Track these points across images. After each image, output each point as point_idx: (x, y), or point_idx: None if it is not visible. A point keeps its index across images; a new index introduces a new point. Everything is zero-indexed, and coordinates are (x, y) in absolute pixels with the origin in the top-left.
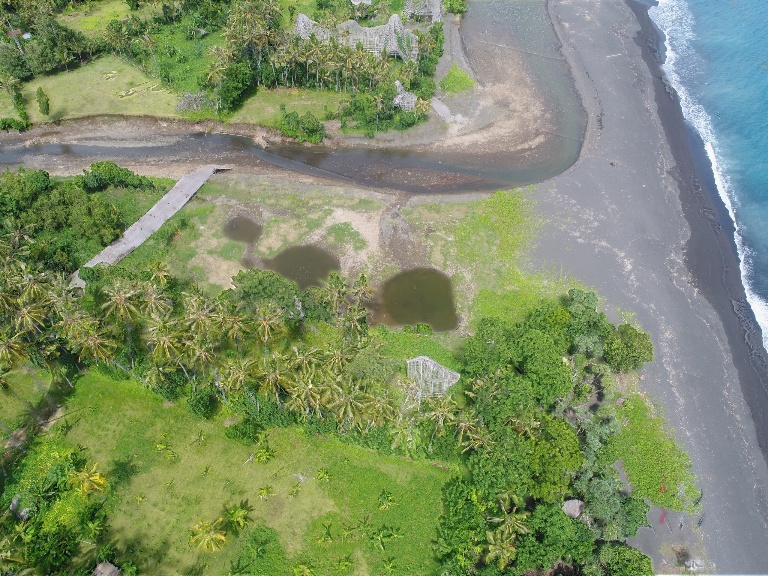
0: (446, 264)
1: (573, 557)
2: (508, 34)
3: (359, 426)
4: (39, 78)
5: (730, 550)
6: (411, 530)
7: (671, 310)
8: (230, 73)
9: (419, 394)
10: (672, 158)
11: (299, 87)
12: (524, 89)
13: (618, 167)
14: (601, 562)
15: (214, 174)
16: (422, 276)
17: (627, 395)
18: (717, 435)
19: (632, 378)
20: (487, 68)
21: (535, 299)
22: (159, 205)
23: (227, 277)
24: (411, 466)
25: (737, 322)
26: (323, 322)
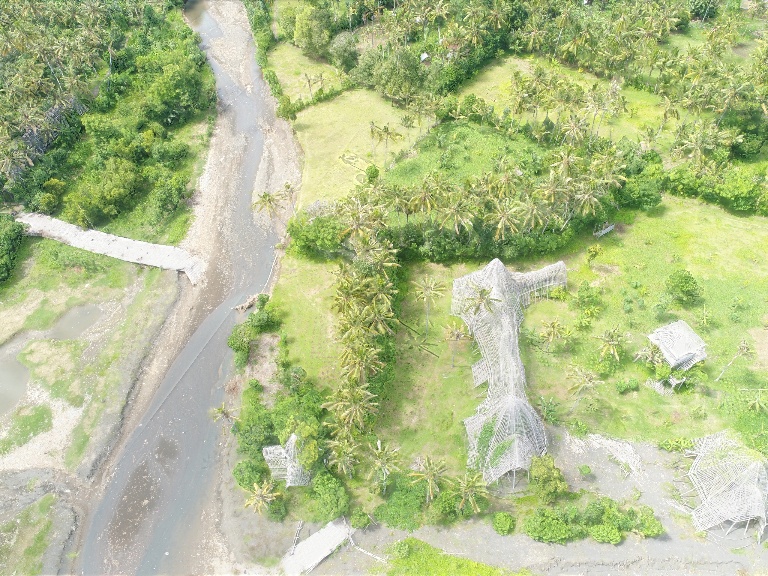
0: None
1: None
2: None
3: None
4: (377, 93)
5: None
6: None
7: None
8: (317, 222)
9: None
10: None
11: None
12: None
13: None
14: None
15: (177, 271)
16: None
17: None
18: None
19: None
20: None
21: None
22: (128, 242)
23: (1, 324)
24: None
25: None
26: None
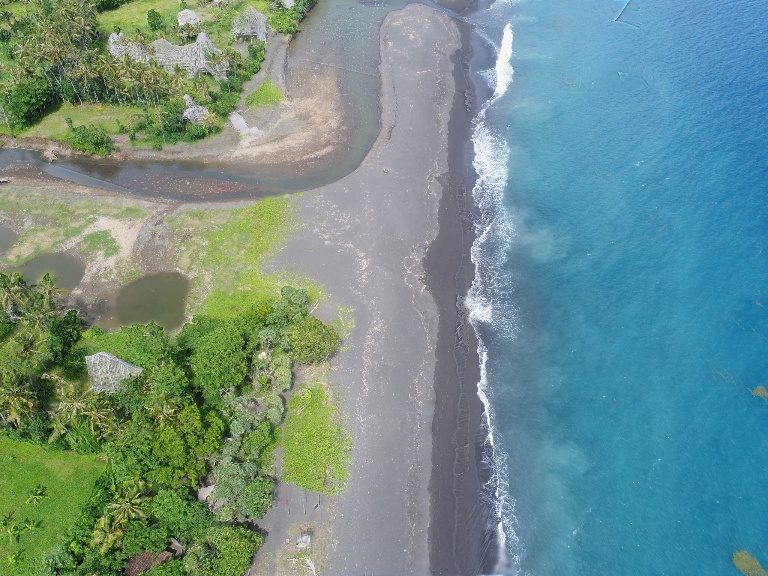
0: (190, 268)
1: (186, 539)
2: (333, 53)
3: (16, 422)
4: None
5: (361, 528)
6: (52, 522)
7: (390, 305)
8: (20, 89)
9: (101, 390)
10: (446, 165)
11: (104, 103)
12: (329, 103)
13: (389, 174)
14: (208, 542)
15: None
16: (164, 280)
17: (311, 385)
18: (391, 420)
19: (322, 369)
20: (301, 84)
21: (264, 298)
22: None
23: None
24: (77, 461)
25: (455, 315)
26: (40, 325)
